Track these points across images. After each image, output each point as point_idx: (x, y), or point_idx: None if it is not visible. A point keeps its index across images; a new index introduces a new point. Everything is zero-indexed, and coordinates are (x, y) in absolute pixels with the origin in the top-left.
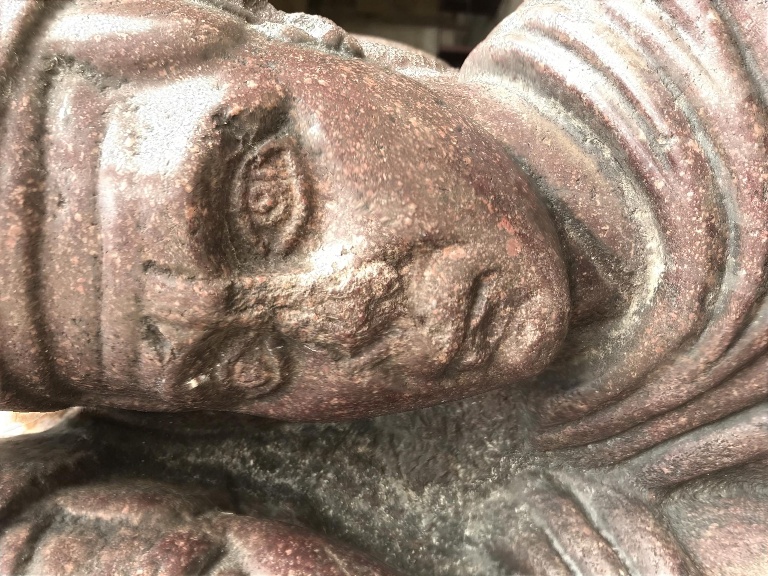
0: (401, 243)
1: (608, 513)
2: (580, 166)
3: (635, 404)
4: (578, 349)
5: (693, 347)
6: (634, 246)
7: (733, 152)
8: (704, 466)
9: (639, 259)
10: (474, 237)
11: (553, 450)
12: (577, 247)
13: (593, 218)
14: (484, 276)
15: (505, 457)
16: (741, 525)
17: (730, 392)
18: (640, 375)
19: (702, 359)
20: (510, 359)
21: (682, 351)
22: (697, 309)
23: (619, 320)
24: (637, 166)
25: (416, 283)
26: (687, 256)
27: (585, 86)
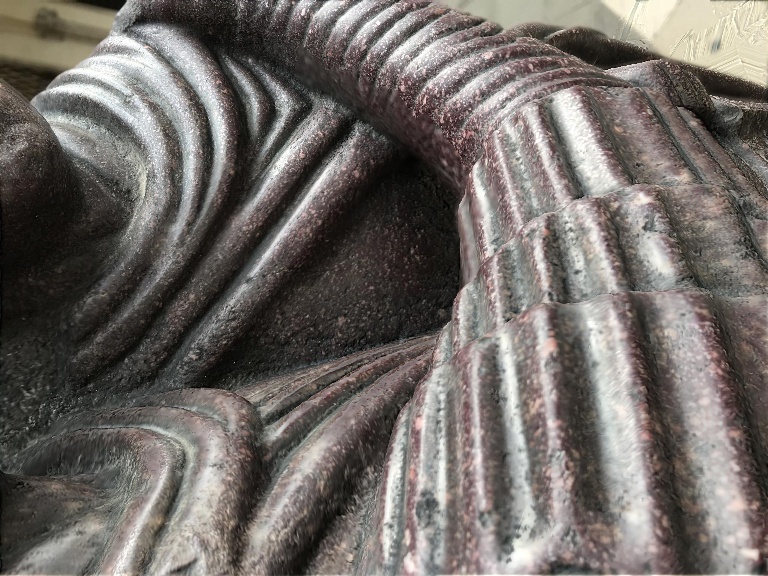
0: None
1: (145, 399)
2: (84, 136)
3: (149, 285)
4: (98, 259)
5: (176, 217)
6: (128, 174)
7: (169, 94)
8: (221, 339)
9: (133, 182)
10: None
11: (93, 379)
12: (83, 173)
13: (94, 157)
14: None
15: (45, 404)
16: None
17: (217, 257)
18: (144, 251)
19: (184, 223)
20: (2, 162)
21: (170, 223)
22: (170, 186)
23: (127, 228)
24: (116, 117)
25: None
26: (155, 154)
27: (81, 90)
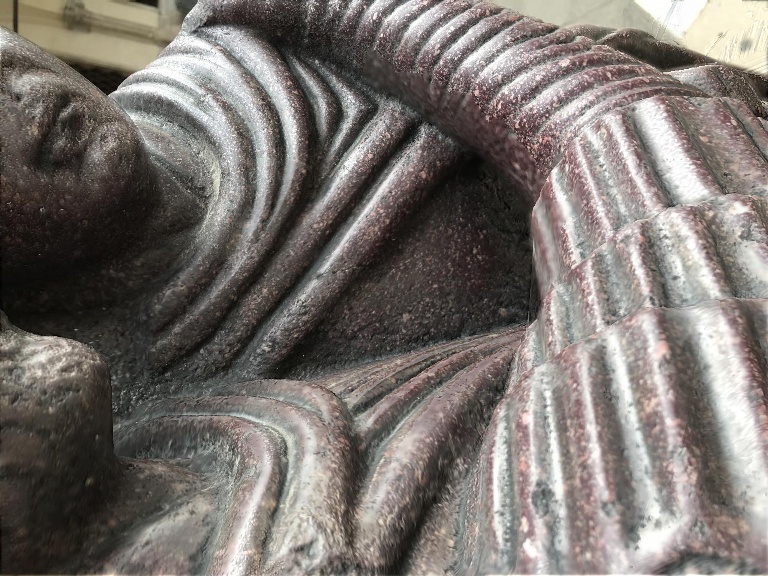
0: (4, 50)
1: (222, 389)
2: (159, 133)
3: (224, 278)
4: (175, 253)
5: (251, 214)
6: (202, 171)
7: (242, 94)
8: (293, 332)
9: (207, 178)
10: (64, 73)
11: (171, 368)
12: (161, 169)
13: (170, 154)
14: (72, 95)
15: (125, 390)
16: (334, 375)
17: (288, 253)
18: (221, 246)
19: (258, 219)
20: (97, 159)
21: (245, 219)
22: (245, 183)
23: (202, 224)
24: (191, 115)
25: (14, 76)
26: (230, 152)
27: (155, 89)
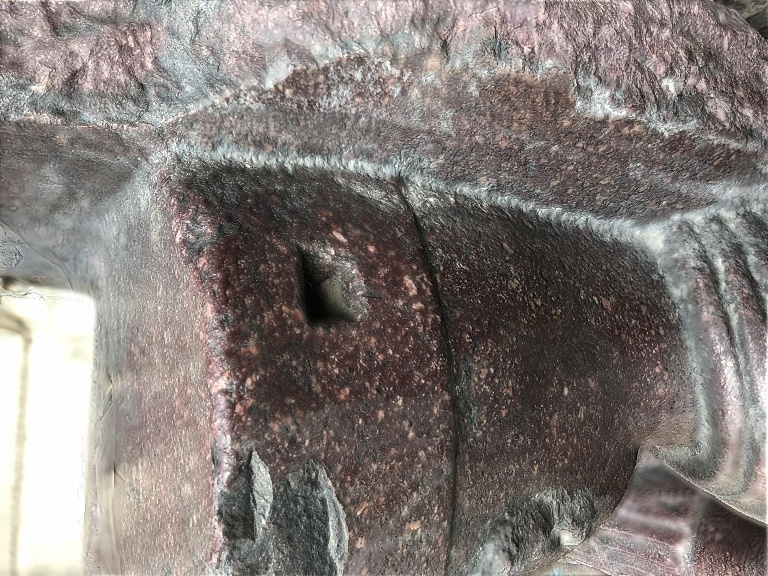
0: None
1: None
2: None
3: None
4: None
5: None
6: None
7: None
8: None
9: None
10: None
11: None
12: None
13: None
14: None
15: None
16: None
17: None
18: None
19: None
20: None
21: None
22: None
23: None
24: None
25: None
26: None
27: None
